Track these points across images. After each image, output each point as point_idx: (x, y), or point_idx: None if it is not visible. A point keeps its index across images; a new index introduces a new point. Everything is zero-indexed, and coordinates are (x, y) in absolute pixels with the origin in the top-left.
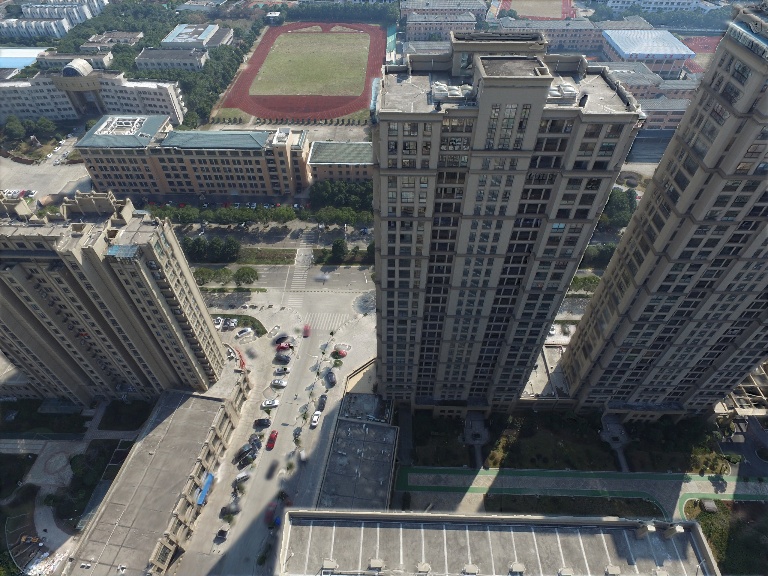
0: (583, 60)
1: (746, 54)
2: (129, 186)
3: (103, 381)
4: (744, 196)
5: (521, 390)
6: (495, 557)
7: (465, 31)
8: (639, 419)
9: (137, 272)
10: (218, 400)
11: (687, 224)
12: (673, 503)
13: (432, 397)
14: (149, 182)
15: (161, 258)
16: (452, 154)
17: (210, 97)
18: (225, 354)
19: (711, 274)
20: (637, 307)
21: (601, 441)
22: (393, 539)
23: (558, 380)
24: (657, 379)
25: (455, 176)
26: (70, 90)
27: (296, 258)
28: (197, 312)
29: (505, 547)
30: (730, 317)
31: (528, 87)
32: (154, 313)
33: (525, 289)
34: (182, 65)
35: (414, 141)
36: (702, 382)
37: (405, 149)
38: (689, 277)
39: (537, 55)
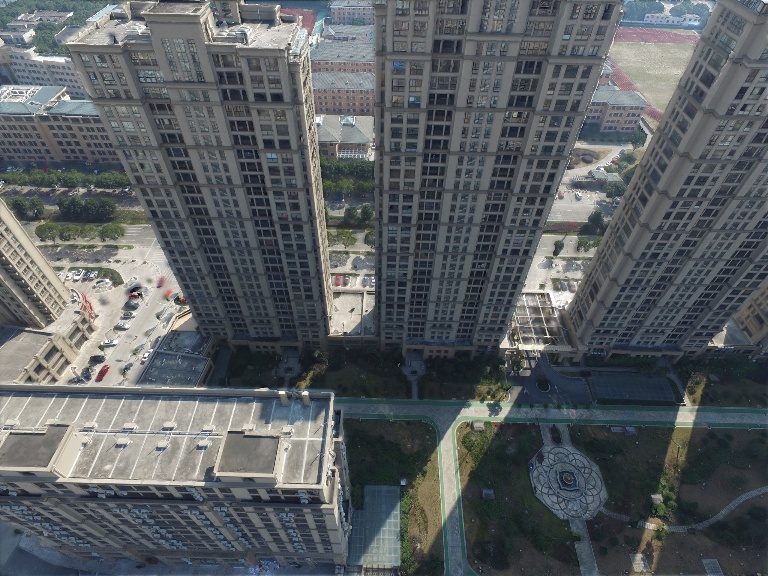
0: (274, 9)
1: None
2: (24, 153)
3: None
4: (413, 128)
5: (327, 327)
6: (156, 418)
7: None
8: (437, 355)
9: None
10: (48, 334)
11: None
12: (448, 424)
13: (249, 334)
14: (42, 149)
15: None
16: (152, 86)
17: None
18: (69, 298)
19: (431, 206)
20: (382, 239)
21: (400, 374)
22: (76, 406)
23: (369, 321)
24: (438, 314)
25: (165, 107)
26: None
27: None
28: (20, 251)
29: (168, 412)
30: (468, 250)
31: (183, 23)
32: None
33: (274, 219)
34: None
35: (109, 72)
36: (478, 317)
37: (105, 80)
38: (410, 208)
39: (230, 3)
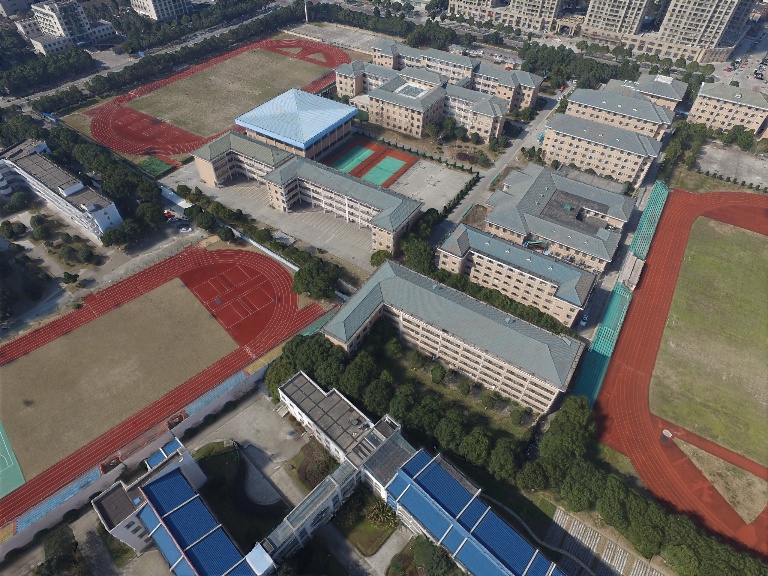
0: None
1: None
2: None
3: None
4: None
5: None
6: None
7: None
8: None
9: None
10: None
11: None
12: None
13: None
14: None
15: None
16: None
17: None
18: None
19: None
20: None
21: None
22: None
23: None
24: None
25: None
26: None
27: None
28: None
29: None
30: None
31: None
32: None
33: None
34: None
35: None
36: None
37: None
38: None
39: None
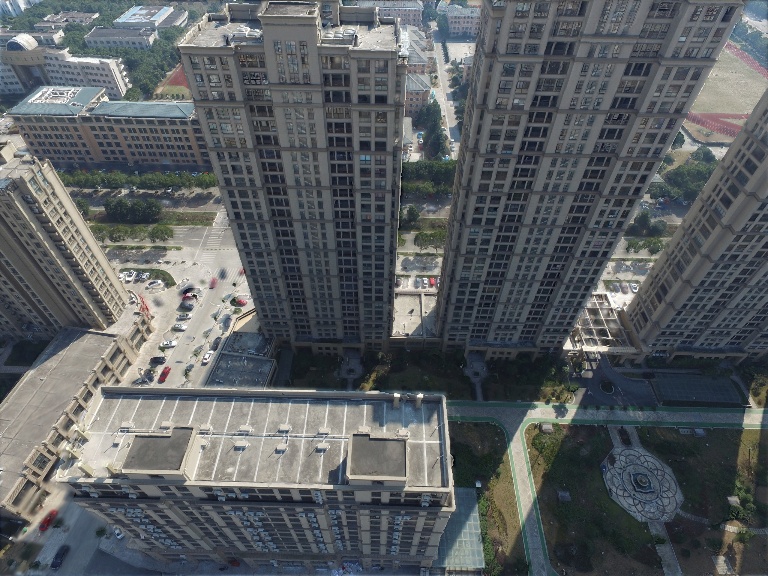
0: (374, 10)
1: (489, 2)
2: (64, 154)
3: (8, 320)
4: (512, 130)
5: (390, 329)
6: (269, 421)
7: (413, 17)
8: (499, 357)
9: (12, 204)
10: (112, 336)
11: (477, 158)
12: (516, 426)
13: (311, 336)
14: (83, 150)
15: (38, 194)
16: (256, 88)
17: (155, 74)
18: (127, 299)
19: (516, 208)
20: (462, 241)
21: (463, 375)
22: (187, 408)
23: (429, 322)
24: (505, 316)
25: (264, 109)
26: (15, 64)
27: (215, 220)
28: (88, 252)
29: (280, 414)
30: (546, 251)
31: (298, 25)
32: (37, 247)
33: (357, 221)
34: (131, 44)
35: (216, 74)
36: (545, 319)
37: (211, 82)
38: (495, 210)
39: (332, 5)
